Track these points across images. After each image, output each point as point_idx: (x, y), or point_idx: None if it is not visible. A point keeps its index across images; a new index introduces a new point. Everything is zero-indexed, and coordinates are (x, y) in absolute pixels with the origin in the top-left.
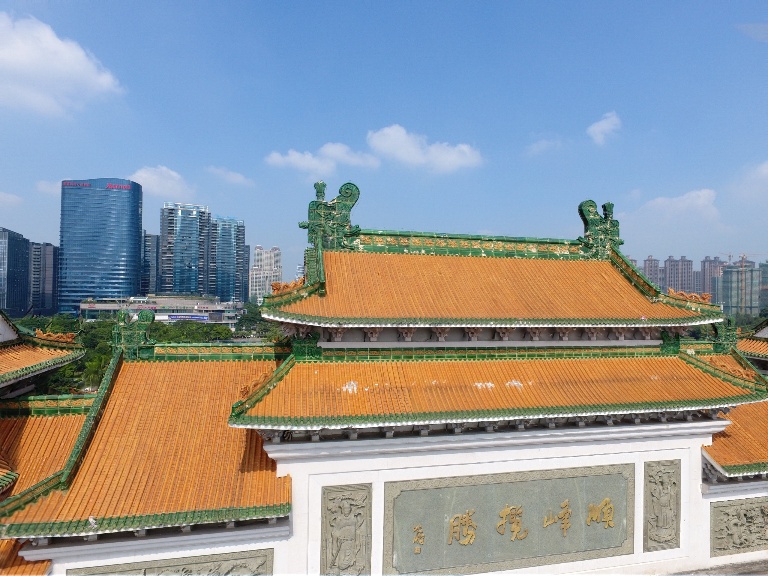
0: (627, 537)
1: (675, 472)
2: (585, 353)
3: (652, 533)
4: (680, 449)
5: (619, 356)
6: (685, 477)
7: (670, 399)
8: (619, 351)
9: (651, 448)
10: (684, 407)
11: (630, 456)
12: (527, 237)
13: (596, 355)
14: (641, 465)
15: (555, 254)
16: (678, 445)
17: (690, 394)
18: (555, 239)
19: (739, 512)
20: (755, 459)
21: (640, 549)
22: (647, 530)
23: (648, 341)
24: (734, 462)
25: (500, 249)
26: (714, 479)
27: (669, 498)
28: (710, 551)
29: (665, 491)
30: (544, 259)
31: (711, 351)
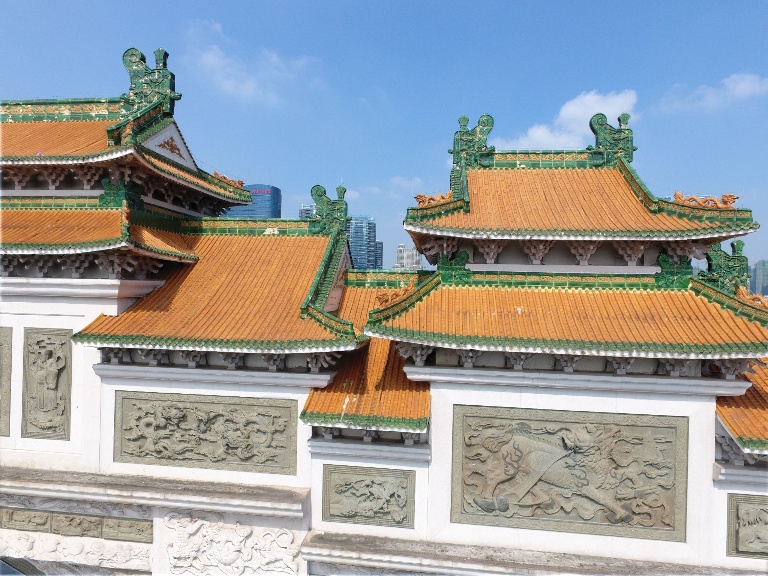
0: (1, 415)
1: (65, 345)
2: (2, 204)
3: (30, 415)
4: (72, 316)
5: (43, 208)
6: (79, 353)
7: (11, 242)
8: (45, 202)
9: (32, 311)
10: (11, 249)
11: (7, 318)
12: (61, 98)
13: (15, 206)
14: (21, 331)
15: (90, 115)
16: (68, 311)
17: (52, 240)
18: (92, 98)
19: (156, 409)
20: (140, 332)
21: (18, 433)
22: (27, 411)
23: (86, 191)
24: (105, 332)
25: (29, 113)
26: (113, 359)
27: (45, 373)
28: (115, 454)
29: (41, 364)
30: (76, 121)
31: (304, 231)
